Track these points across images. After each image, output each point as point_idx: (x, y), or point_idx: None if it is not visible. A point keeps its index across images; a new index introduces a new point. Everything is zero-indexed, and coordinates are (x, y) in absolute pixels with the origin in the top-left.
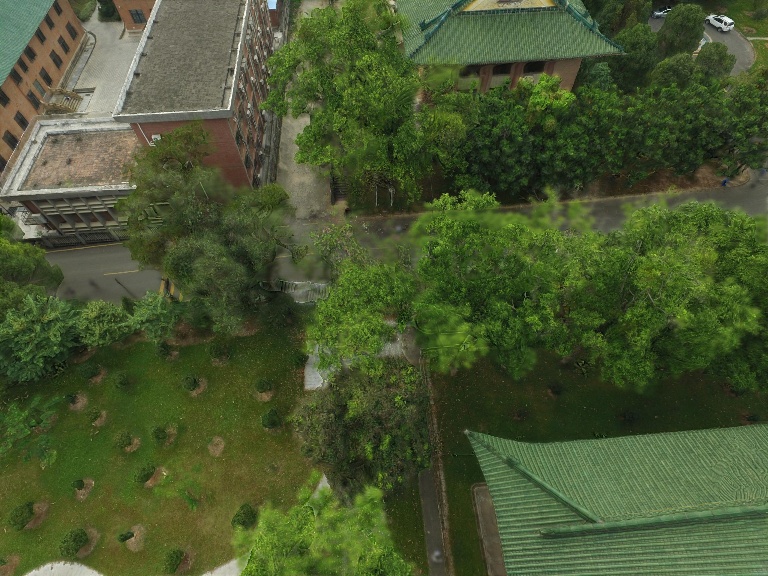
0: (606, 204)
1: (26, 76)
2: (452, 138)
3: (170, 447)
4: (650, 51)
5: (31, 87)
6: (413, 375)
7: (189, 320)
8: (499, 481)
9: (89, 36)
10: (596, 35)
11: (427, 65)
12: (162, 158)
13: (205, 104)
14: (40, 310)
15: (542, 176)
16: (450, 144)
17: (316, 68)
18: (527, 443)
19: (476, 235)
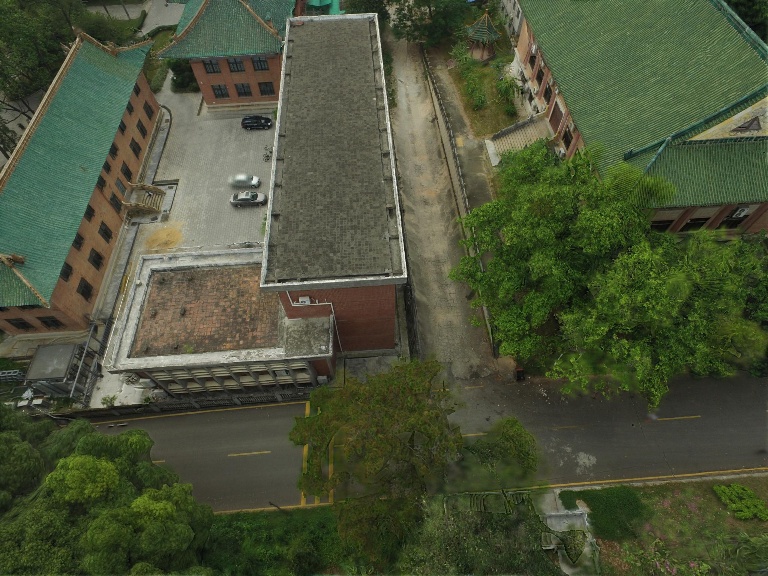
0: None
1: (109, 177)
2: None
3: None
4: None
5: (113, 188)
6: None
7: None
8: None
9: (163, 111)
10: None
11: (641, 209)
12: None
13: (372, 265)
14: None
15: None
16: None
17: (550, 250)
18: None
19: None
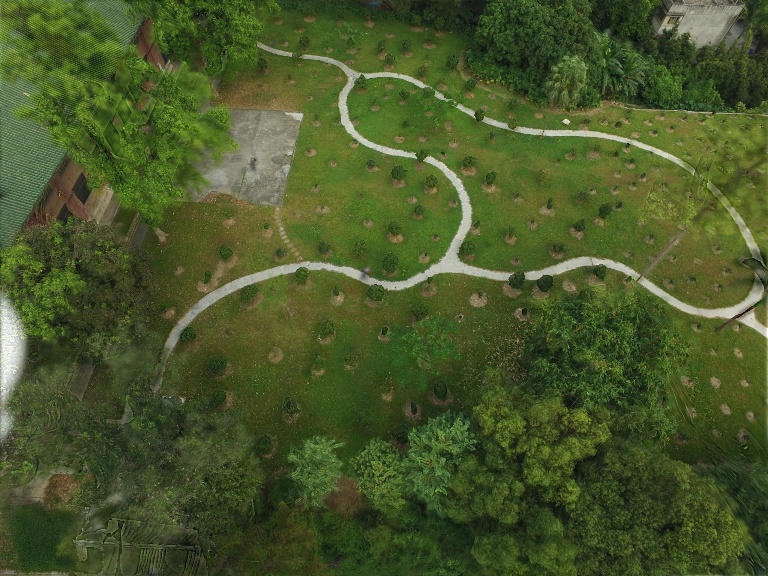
0: None
1: None
2: None
3: None
4: None
5: None
6: None
7: None
8: (8, 228)
9: None
10: None
11: None
12: None
13: None
14: None
15: None
16: None
17: None
18: None
19: None
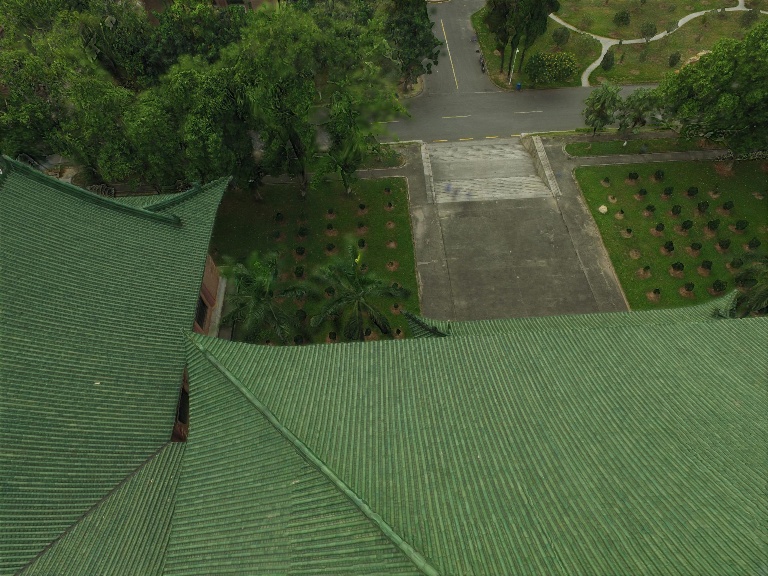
0: None
1: None
2: (123, 44)
3: None
4: None
5: None
6: None
7: None
8: None
9: None
10: None
11: None
12: None
13: None
14: None
15: None
16: (121, 48)
17: None
18: None
19: None
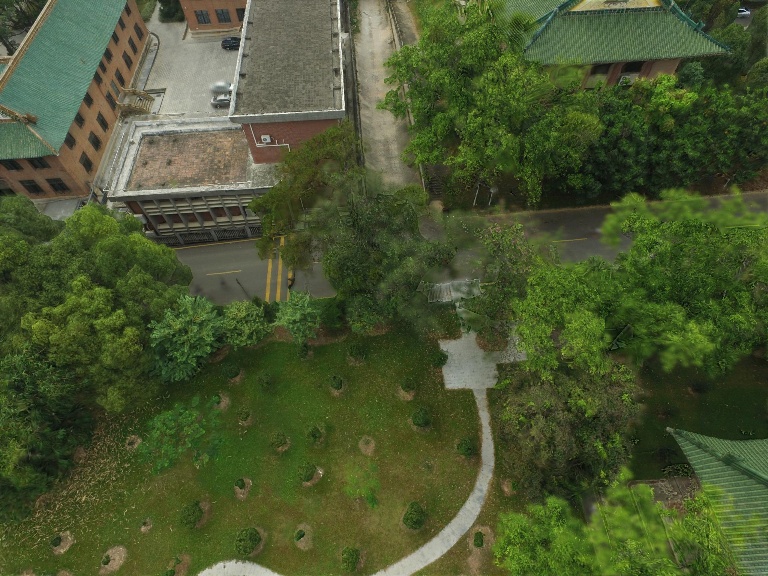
0: (702, 203)
1: (105, 77)
2: (569, 138)
3: (321, 446)
4: (744, 51)
5: (109, 88)
6: (627, 373)
7: (322, 320)
8: (713, 478)
9: (152, 37)
10: (700, 35)
11: None
12: (321, 158)
13: (318, 104)
14: (191, 310)
15: (653, 175)
16: (567, 144)
17: (446, 68)
18: (728, 440)
19: (699, 234)
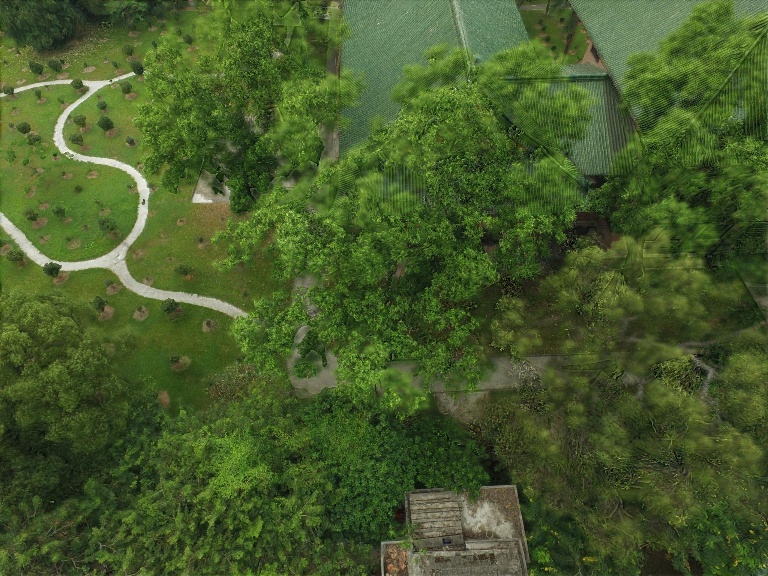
0: None
1: None
2: None
3: (200, 41)
4: None
5: None
6: None
7: None
8: None
9: None
10: None
11: None
12: None
13: None
14: None
15: None
16: None
17: None
18: None
19: None
